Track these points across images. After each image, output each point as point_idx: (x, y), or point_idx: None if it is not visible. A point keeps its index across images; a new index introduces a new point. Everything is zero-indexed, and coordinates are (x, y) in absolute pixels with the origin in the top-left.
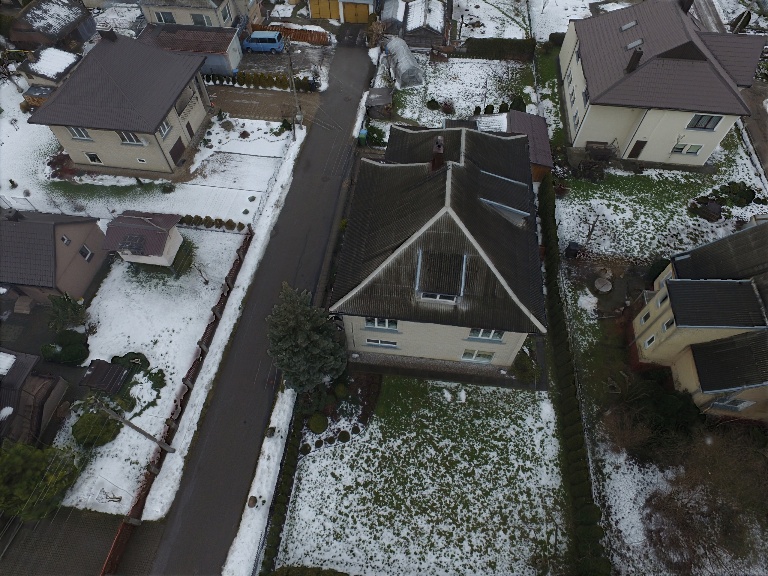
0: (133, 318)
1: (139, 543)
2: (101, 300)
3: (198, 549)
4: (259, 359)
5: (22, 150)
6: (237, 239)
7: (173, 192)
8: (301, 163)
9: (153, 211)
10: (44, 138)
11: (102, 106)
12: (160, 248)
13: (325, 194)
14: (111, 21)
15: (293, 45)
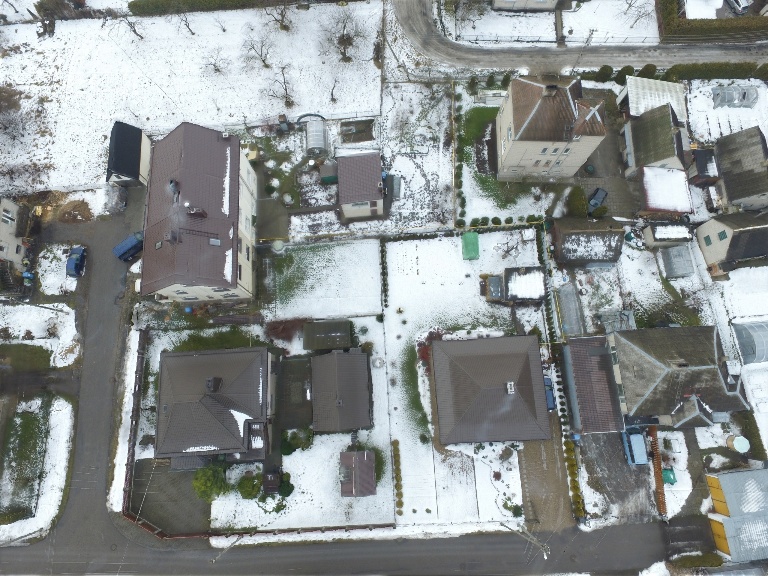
0: (317, 469)
1: (199, 539)
2: (324, 443)
3: (200, 572)
4: (301, 567)
5: (440, 303)
6: (389, 513)
7: (422, 444)
8: (477, 538)
9: (401, 438)
10: (456, 311)
11: (453, 398)
12: (345, 494)
13: (446, 572)
14: (622, 275)
15: (647, 471)
